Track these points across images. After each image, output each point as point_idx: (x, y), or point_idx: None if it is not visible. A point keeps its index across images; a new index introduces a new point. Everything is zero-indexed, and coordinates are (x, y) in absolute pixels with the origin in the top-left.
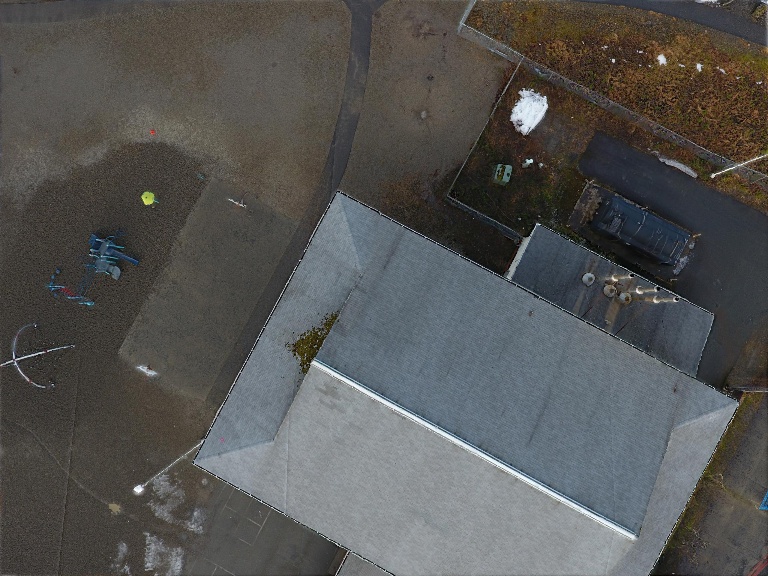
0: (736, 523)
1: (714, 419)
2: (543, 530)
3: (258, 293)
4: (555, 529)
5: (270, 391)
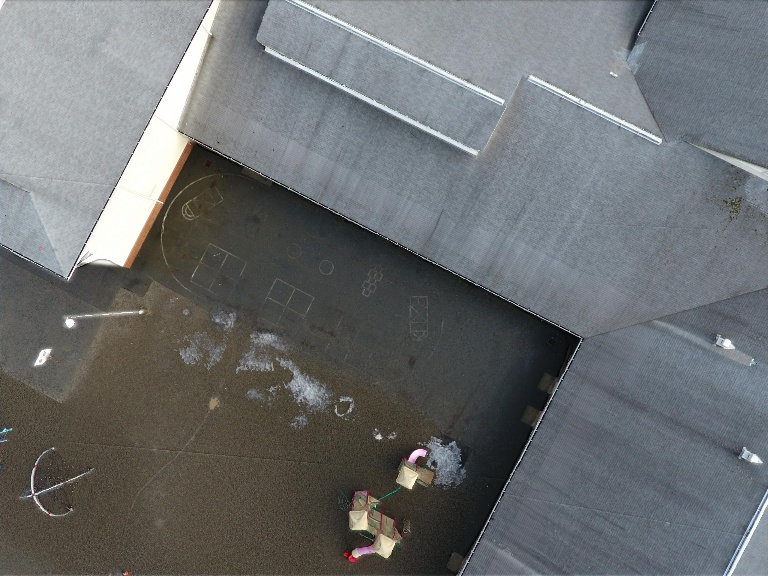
0: None
1: None
2: None
3: (2, 262)
4: None
5: None
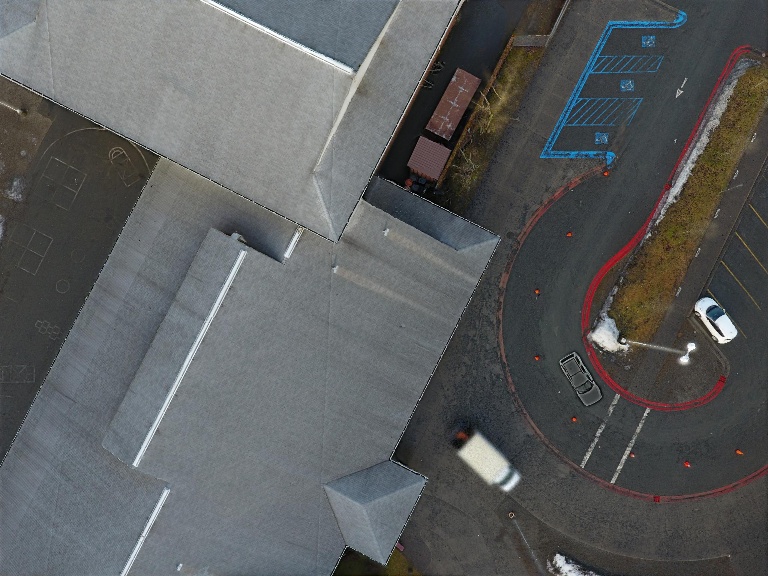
0: (518, 171)
1: None
2: (275, 78)
3: None
4: (284, 75)
5: None
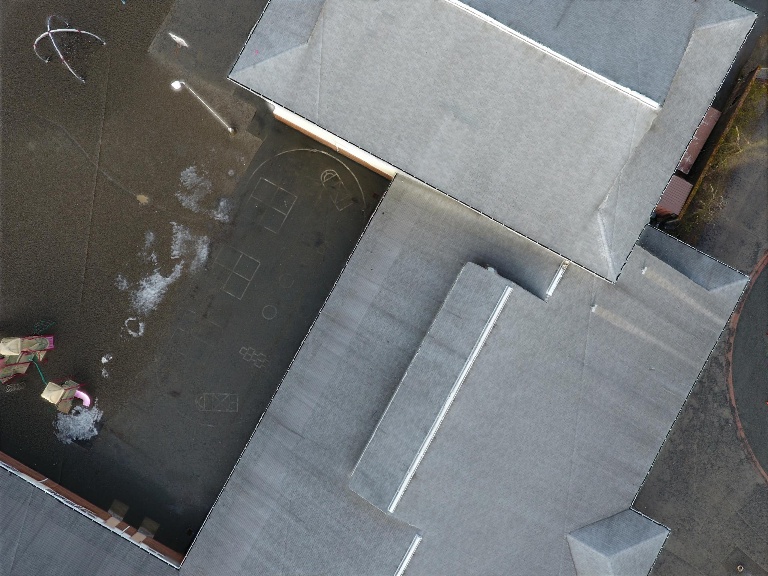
0: (751, 208)
1: (734, 27)
2: (569, 110)
3: None
4: (581, 107)
5: (304, 2)
